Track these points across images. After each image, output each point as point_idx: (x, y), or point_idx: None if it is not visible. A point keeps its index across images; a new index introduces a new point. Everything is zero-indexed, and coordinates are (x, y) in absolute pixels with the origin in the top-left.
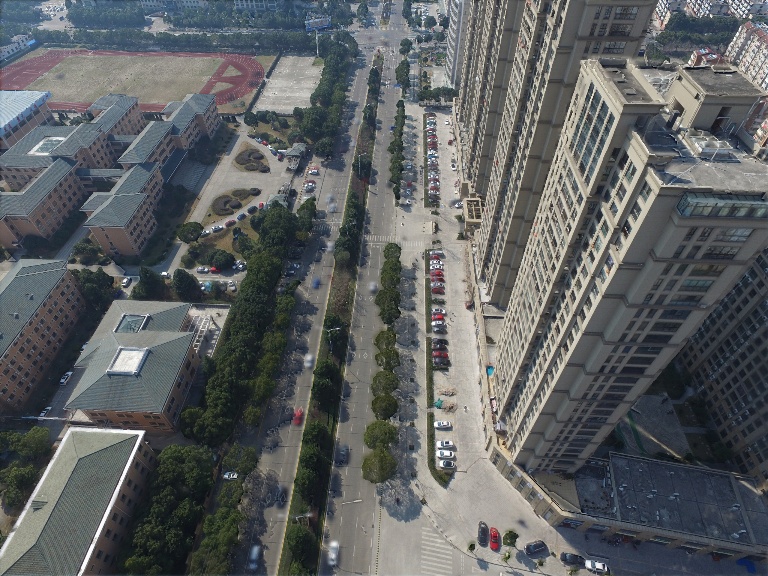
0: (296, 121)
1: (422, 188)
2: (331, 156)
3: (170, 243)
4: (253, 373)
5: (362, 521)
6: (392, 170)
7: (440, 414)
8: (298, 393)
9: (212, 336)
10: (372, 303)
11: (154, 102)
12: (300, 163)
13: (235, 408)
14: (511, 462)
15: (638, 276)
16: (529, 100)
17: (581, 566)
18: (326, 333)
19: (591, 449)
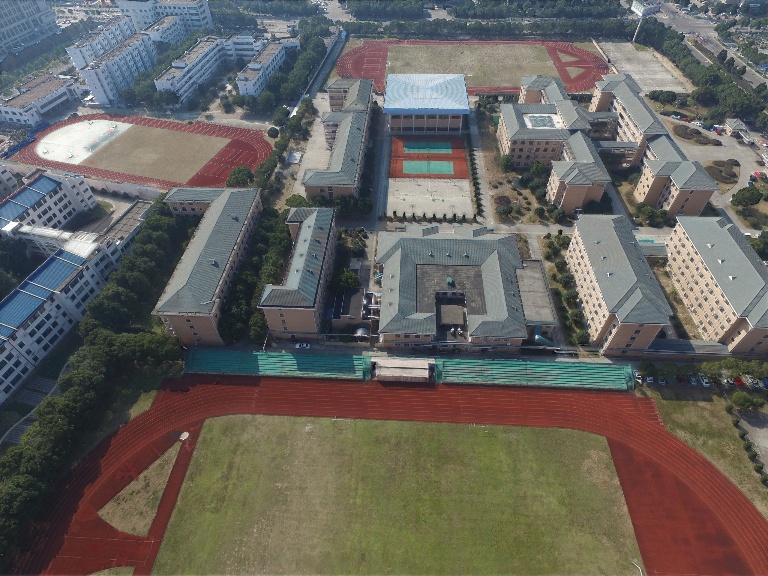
0: (694, 100)
1: None
2: (764, 131)
3: (713, 208)
4: None
5: None
6: None
7: None
8: None
9: None
10: None
11: None
12: None
13: None
14: None
15: None
16: None
17: None
18: None
19: None
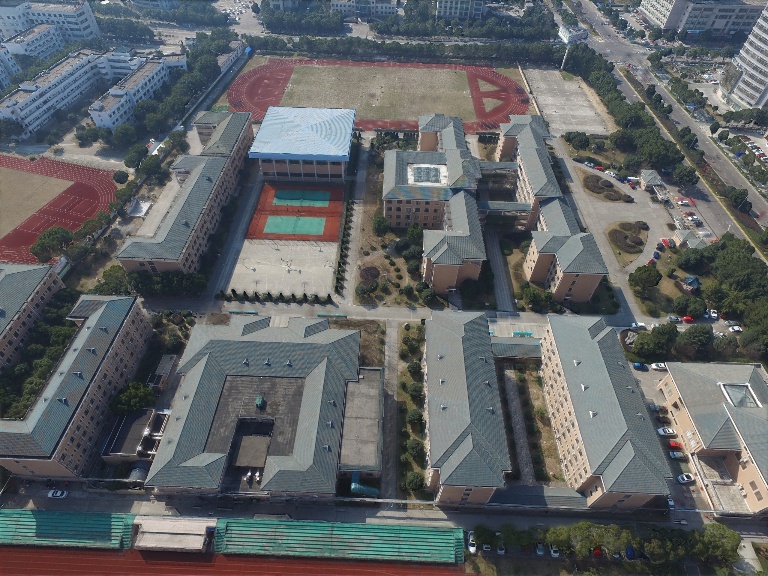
0: (612, 144)
1: None
2: (682, 184)
3: (609, 287)
4: None
5: None
6: None
7: None
8: None
9: None
10: None
11: None
12: None
13: None
14: None
15: None
16: None
17: None
18: None
19: None
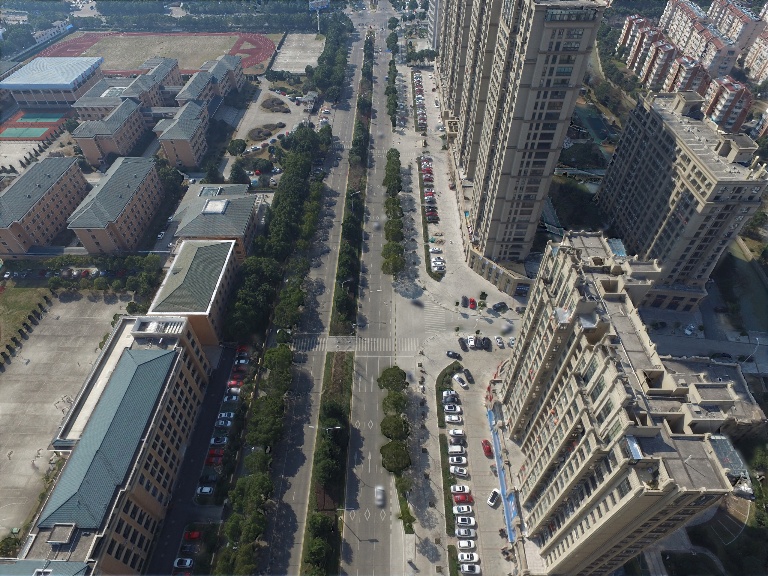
0: (307, 78)
1: (413, 120)
2: (338, 101)
3: (220, 158)
4: (299, 223)
5: (383, 299)
6: (389, 106)
7: (433, 245)
8: (331, 239)
9: (264, 208)
10: (380, 189)
11: (186, 68)
12: (314, 106)
13: (290, 240)
14: (482, 256)
15: (535, 68)
16: (484, 14)
17: None
18: (349, 200)
19: (531, 230)
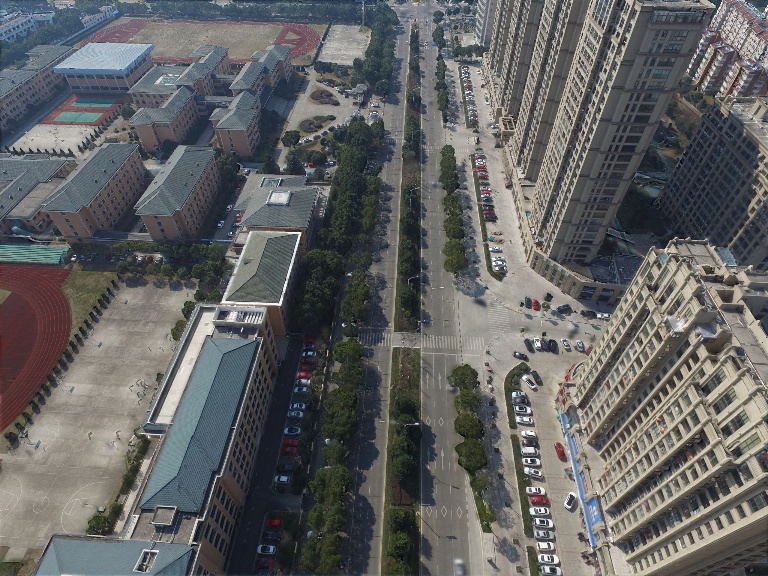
0: (354, 71)
1: (463, 116)
2: (387, 95)
3: (273, 149)
4: (359, 217)
5: (446, 297)
6: (440, 101)
7: (493, 244)
8: (389, 234)
9: (321, 201)
10: (435, 185)
11: (233, 57)
12: (363, 99)
13: (351, 234)
14: (547, 257)
15: (631, 70)
16: (561, 12)
17: (594, 317)
18: (407, 196)
19: (601, 233)
